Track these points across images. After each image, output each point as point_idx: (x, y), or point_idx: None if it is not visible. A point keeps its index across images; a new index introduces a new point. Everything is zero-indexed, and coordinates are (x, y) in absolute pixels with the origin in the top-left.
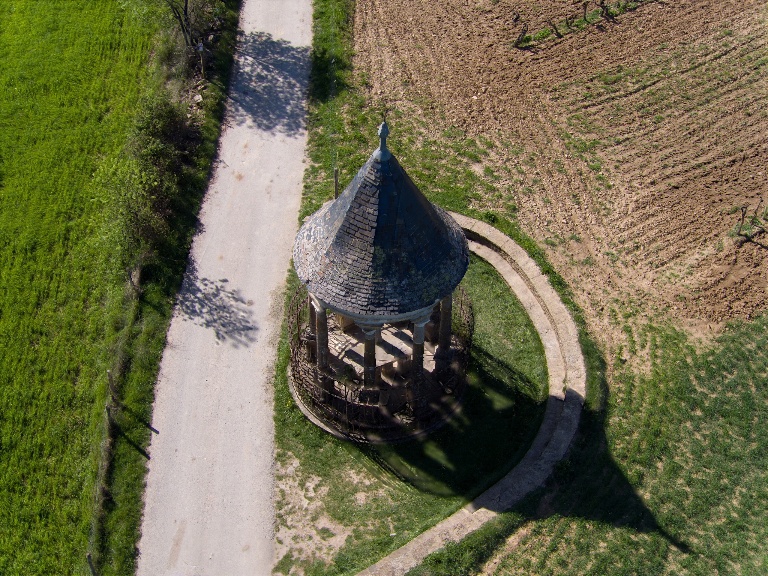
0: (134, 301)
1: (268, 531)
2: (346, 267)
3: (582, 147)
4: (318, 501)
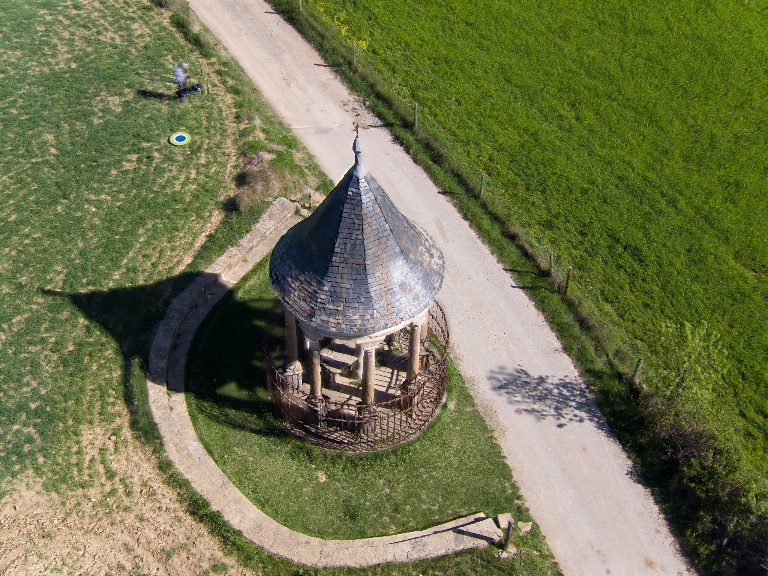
0: None
1: None
2: None
3: None
4: None
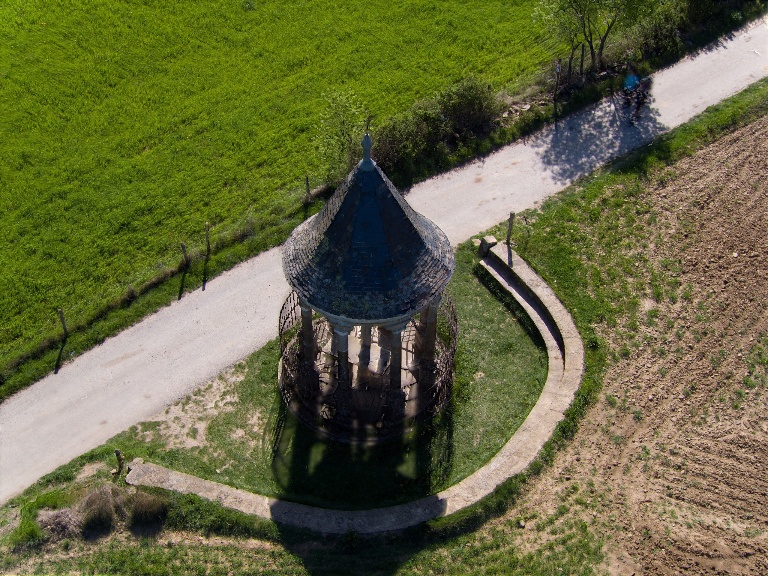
0: (299, 203)
1: (171, 399)
2: (307, 239)
3: (764, 359)
4: (217, 411)
